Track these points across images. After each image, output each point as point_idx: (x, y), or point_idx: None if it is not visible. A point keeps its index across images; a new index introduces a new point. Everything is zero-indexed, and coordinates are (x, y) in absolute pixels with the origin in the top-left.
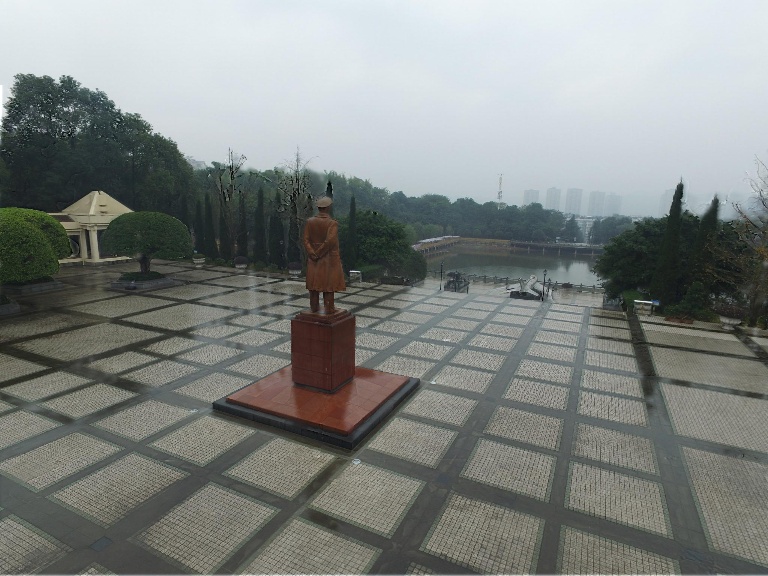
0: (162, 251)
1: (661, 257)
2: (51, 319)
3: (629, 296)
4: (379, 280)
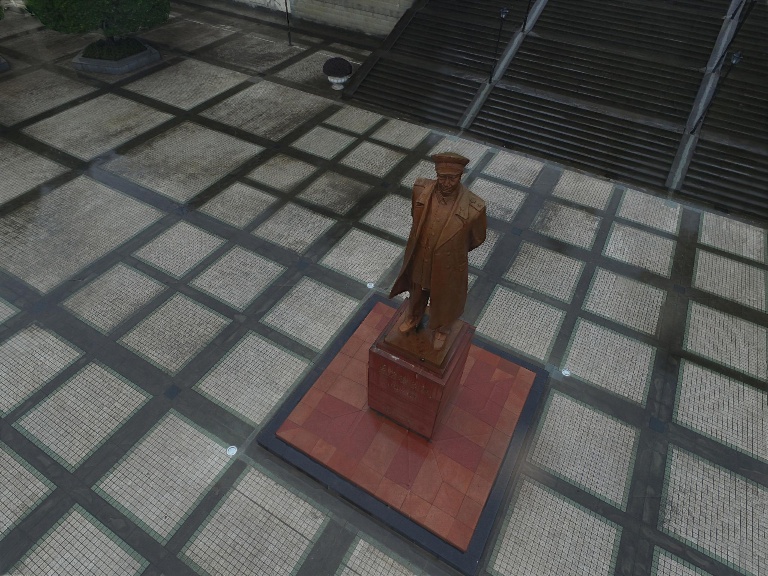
0: None
1: None
2: None
3: None
4: None
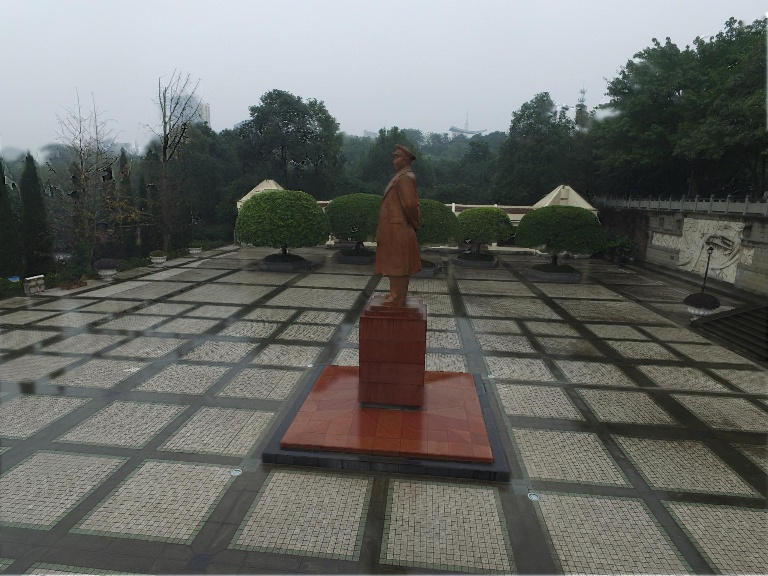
0: None
1: (0, 225)
2: None
3: None
4: None
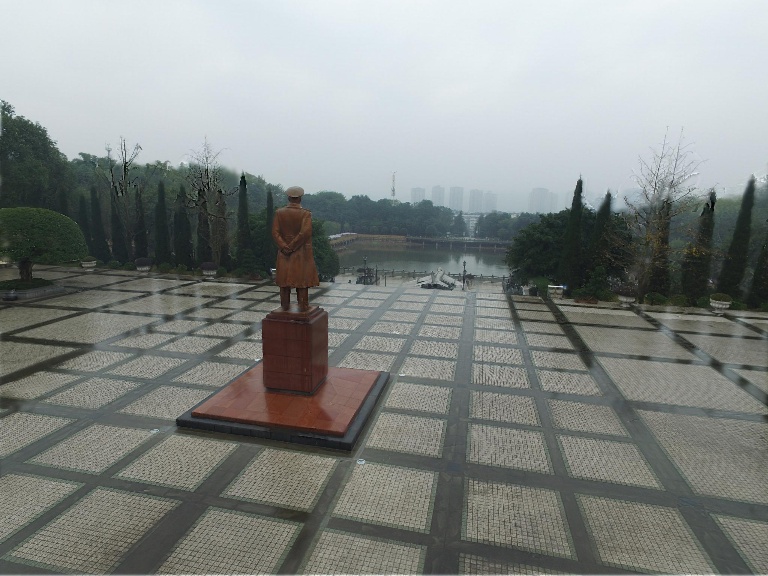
0: (51, 253)
1: (566, 246)
2: None
3: (541, 282)
4: None
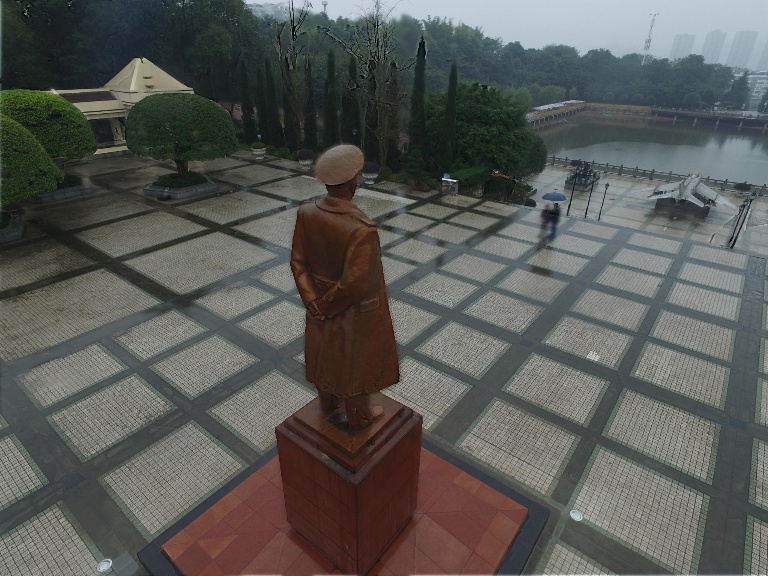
0: (194, 151)
1: None
2: (43, 256)
3: None
4: (482, 186)
